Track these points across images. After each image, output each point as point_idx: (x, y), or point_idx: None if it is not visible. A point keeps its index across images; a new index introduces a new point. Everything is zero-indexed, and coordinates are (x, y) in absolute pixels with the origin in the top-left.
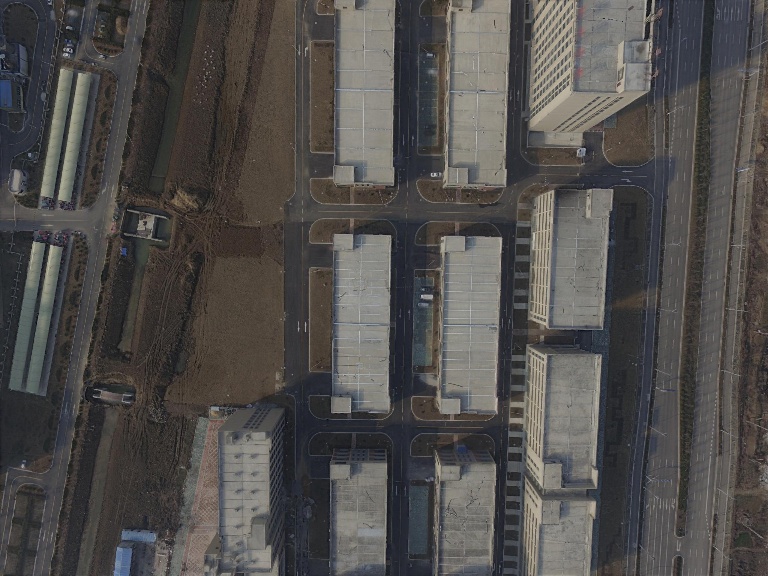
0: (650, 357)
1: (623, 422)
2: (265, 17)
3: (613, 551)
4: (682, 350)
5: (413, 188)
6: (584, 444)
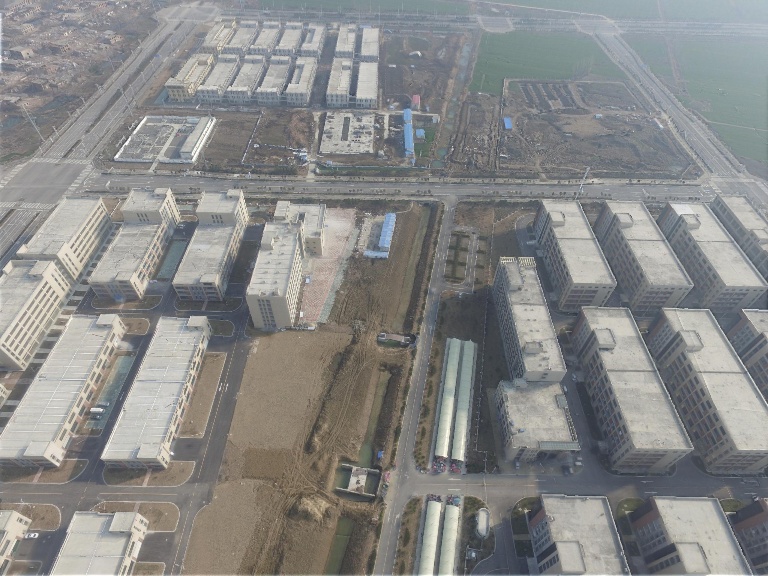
0: None
1: None
2: None
3: None
4: None
5: (65, 521)
6: (5, 288)
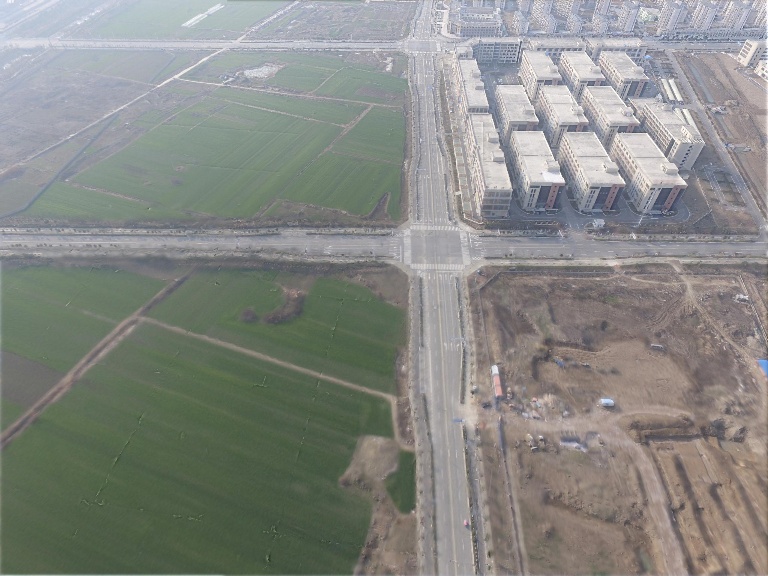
0: None
1: None
2: (727, 74)
3: None
4: None
5: None
6: None
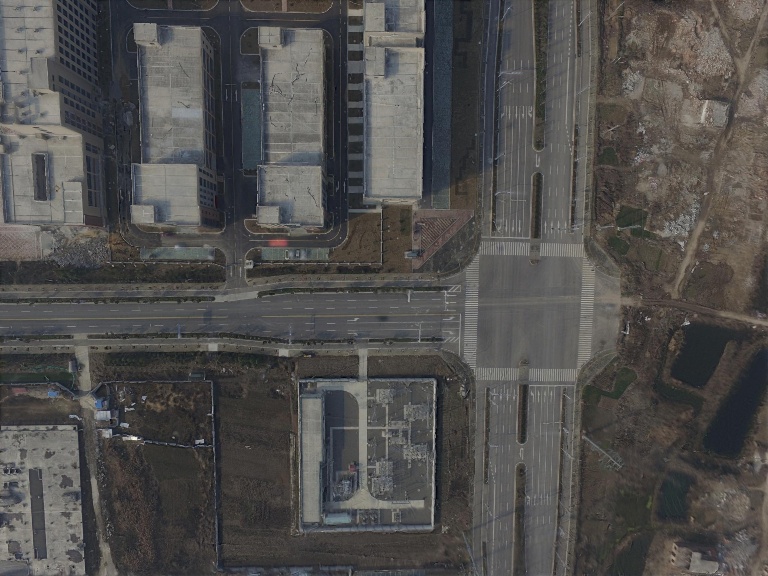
0: None
1: (472, 16)
2: None
3: (467, 166)
4: None
5: None
6: None
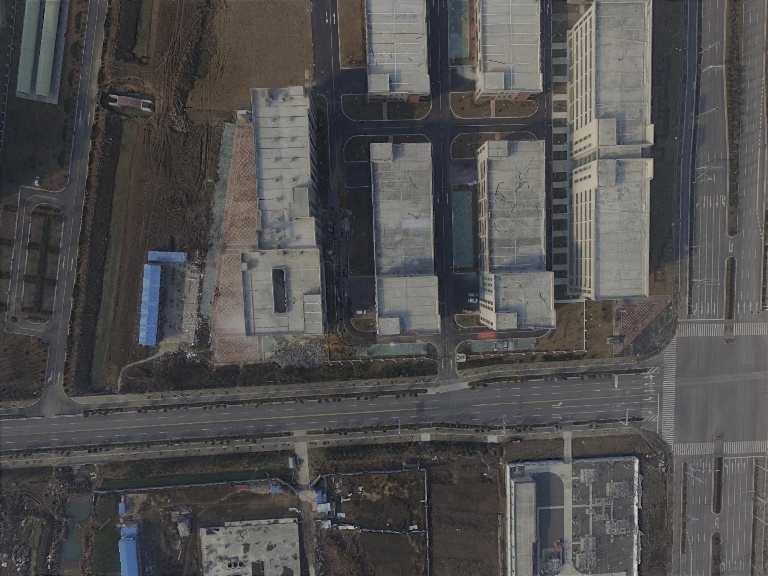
0: (694, 41)
1: (669, 113)
2: None
3: (665, 255)
4: (726, 32)
5: None
6: (637, 102)
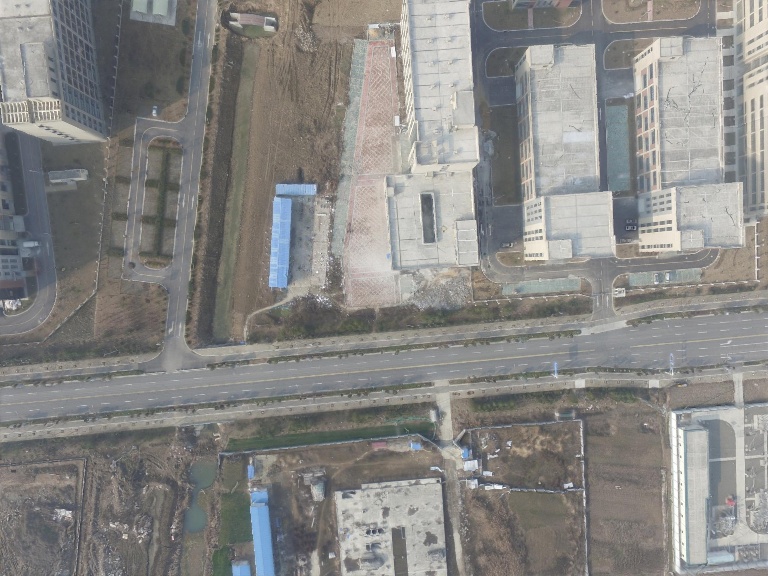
0: None
1: None
2: None
3: None
4: None
5: None
6: None
